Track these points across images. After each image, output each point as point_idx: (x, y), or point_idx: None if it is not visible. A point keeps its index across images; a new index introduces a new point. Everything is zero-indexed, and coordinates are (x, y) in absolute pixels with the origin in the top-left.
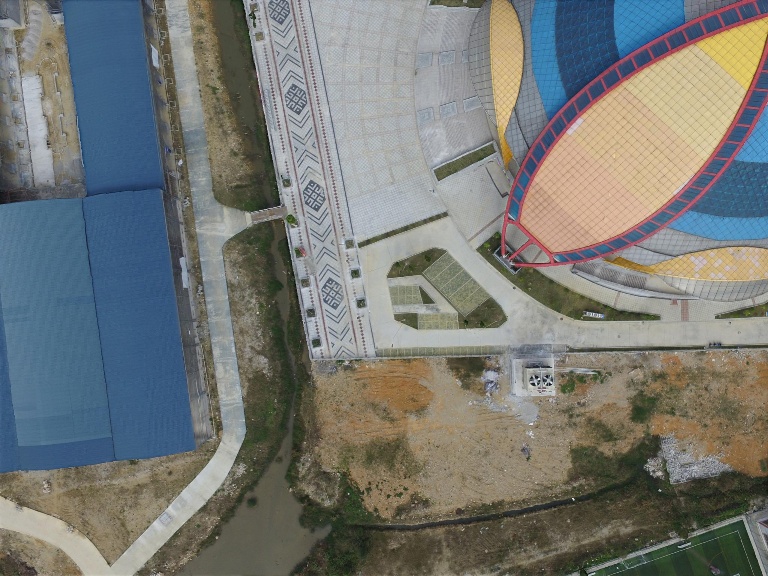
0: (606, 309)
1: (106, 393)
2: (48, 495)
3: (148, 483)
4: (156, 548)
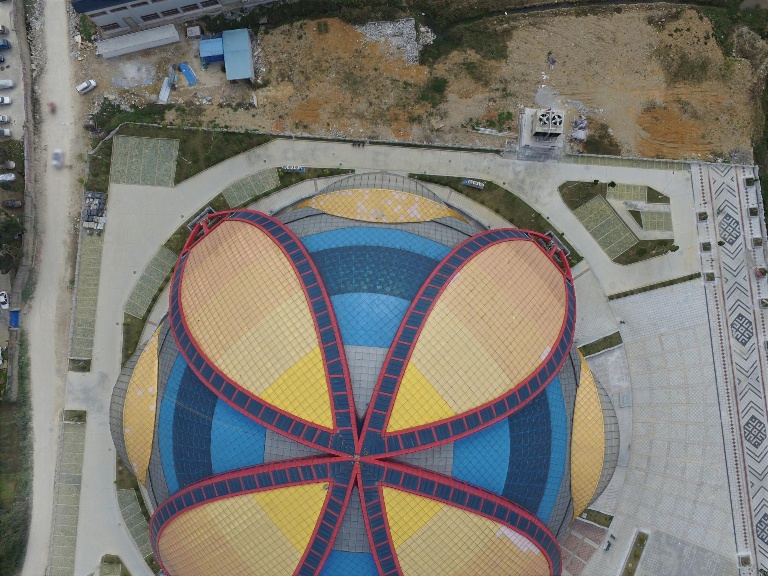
0: (461, 189)
1: None
2: None
3: None
4: None
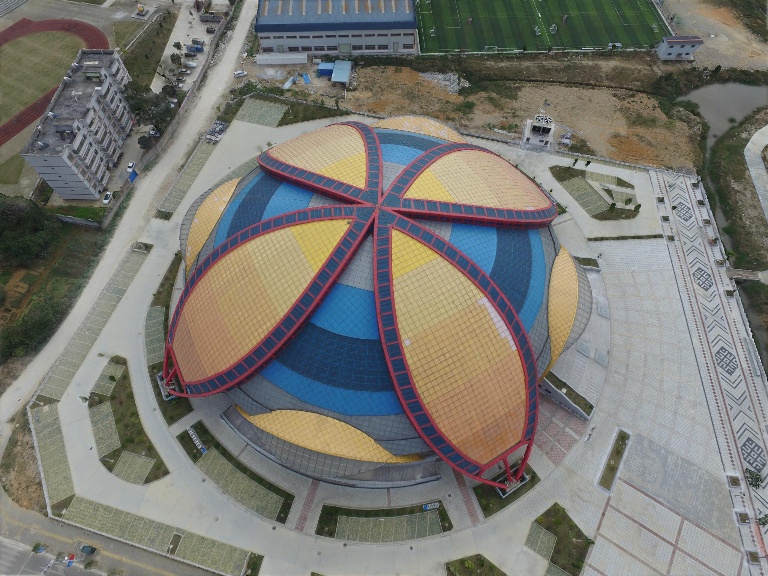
0: None
1: None
2: None
3: None
4: None
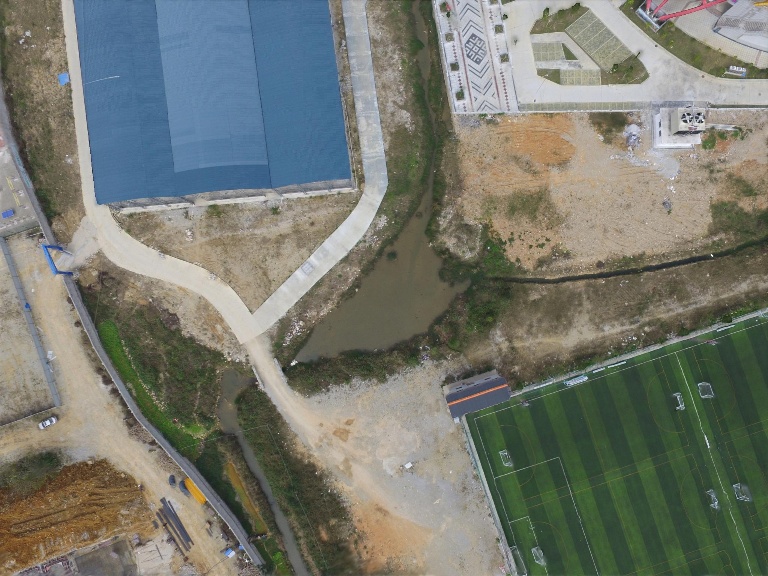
0: (748, 66)
1: (263, 121)
2: (190, 243)
3: (290, 233)
4: (298, 296)
